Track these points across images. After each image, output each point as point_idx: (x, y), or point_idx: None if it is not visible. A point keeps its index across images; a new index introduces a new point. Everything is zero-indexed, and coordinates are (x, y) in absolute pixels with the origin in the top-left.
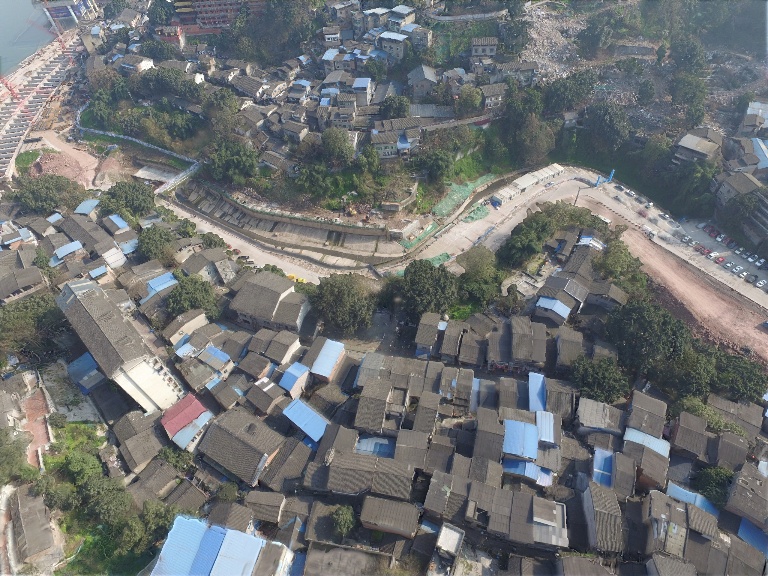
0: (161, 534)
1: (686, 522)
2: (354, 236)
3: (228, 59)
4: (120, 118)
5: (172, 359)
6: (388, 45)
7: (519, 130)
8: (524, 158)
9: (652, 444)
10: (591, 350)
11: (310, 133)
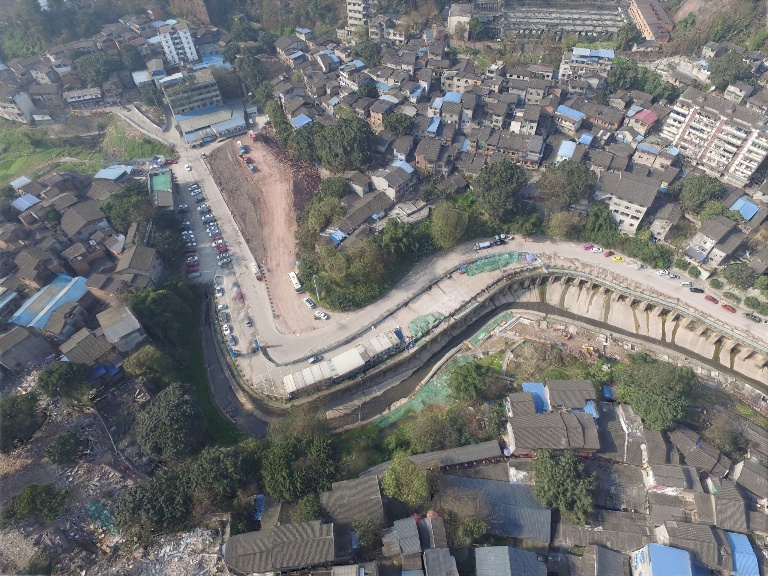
0: None
1: (394, 72)
2: None
3: None
4: None
5: None
6: None
7: None
8: None
9: (387, 98)
10: (390, 144)
11: (725, 469)
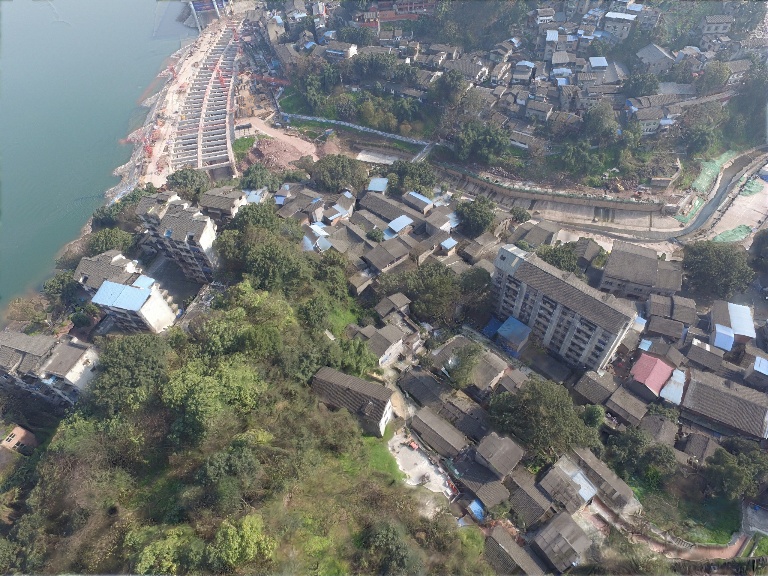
0: (759, 479)
1: None
2: (624, 212)
3: (432, 44)
4: (337, 103)
5: None
6: (612, 25)
7: (765, 106)
8: (765, 134)
9: None
10: None
11: (556, 112)
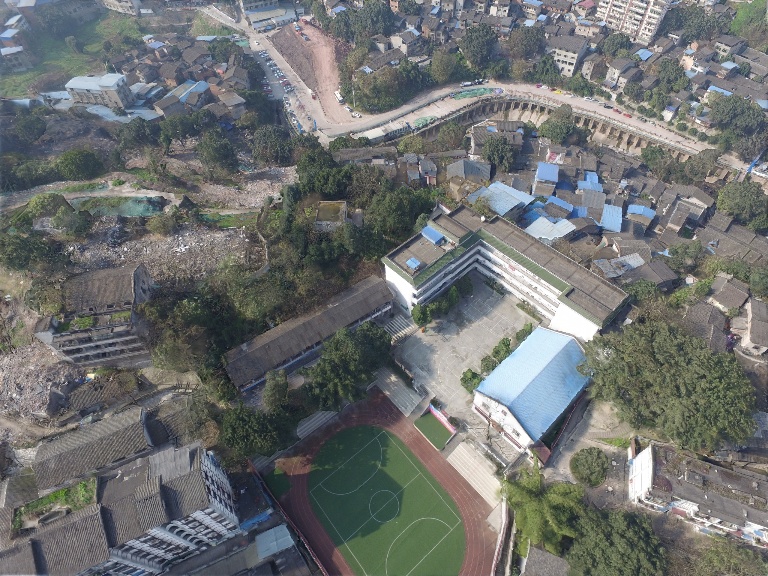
0: None
1: None
2: None
3: None
4: None
5: None
6: None
7: None
8: None
9: None
10: (404, 21)
11: None
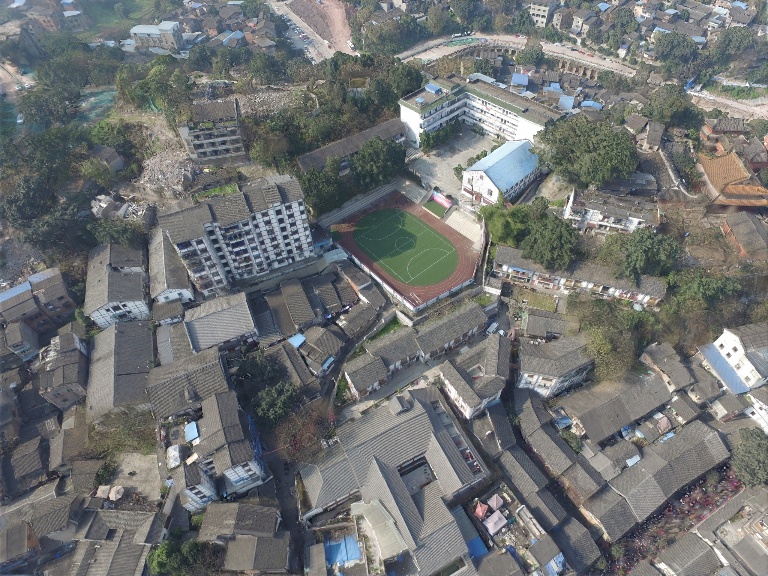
0: None
1: None
2: None
3: None
4: None
5: None
6: None
7: None
8: None
9: None
10: None
11: None
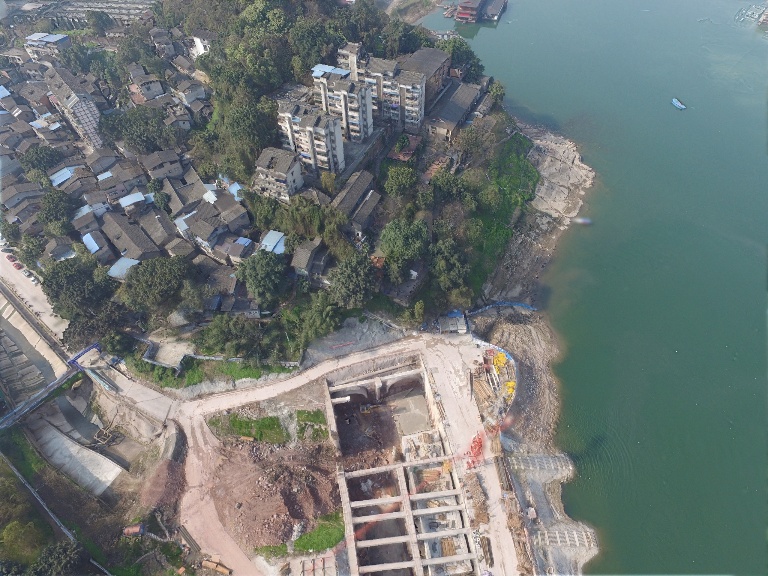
0: None
1: None
2: None
3: None
4: None
5: (72, 135)
6: None
7: None
8: None
9: None
10: None
11: None
